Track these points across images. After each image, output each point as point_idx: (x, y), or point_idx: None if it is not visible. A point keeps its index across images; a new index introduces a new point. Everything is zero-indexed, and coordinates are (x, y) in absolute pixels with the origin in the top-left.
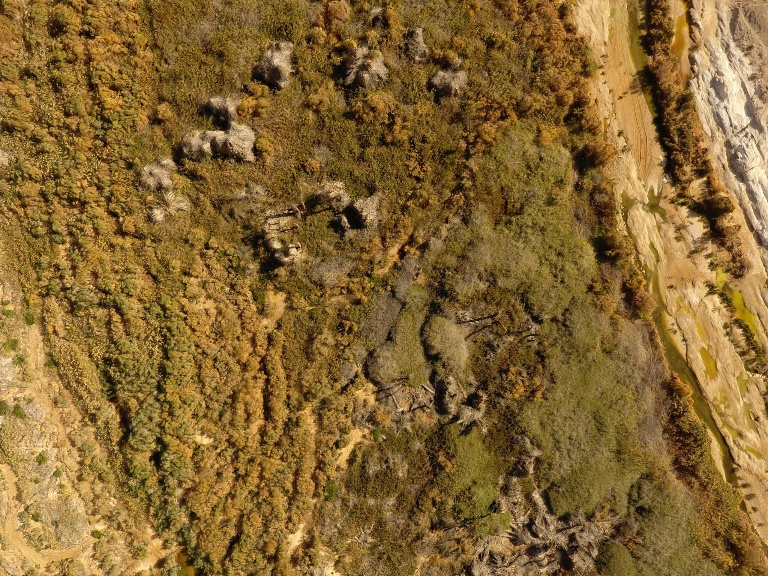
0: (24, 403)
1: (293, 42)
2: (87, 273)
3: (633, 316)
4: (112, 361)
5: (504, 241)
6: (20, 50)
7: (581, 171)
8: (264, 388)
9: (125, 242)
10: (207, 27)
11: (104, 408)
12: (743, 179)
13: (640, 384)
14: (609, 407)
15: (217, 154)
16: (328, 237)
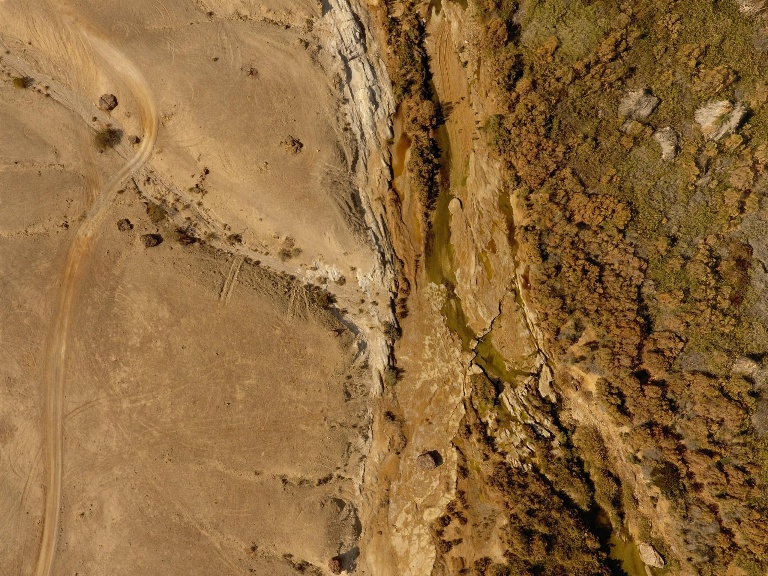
0: None
1: None
2: None
3: None
4: None
5: None
6: None
7: None
8: None
9: None
10: None
11: None
12: (354, 15)
13: None
14: None
15: None
16: None
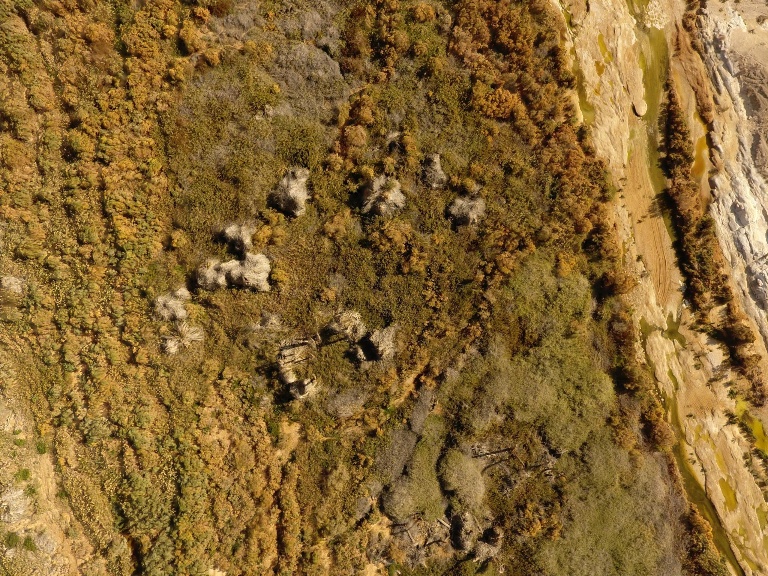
0: (35, 535)
1: (309, 168)
2: (100, 405)
3: (652, 449)
4: (124, 496)
5: (522, 373)
6: (33, 174)
7: (600, 299)
8: (278, 522)
9: (138, 373)
10: (222, 152)
11: (116, 544)
12: (764, 306)
13: (659, 520)
14: (627, 545)
15: (232, 285)
16: (343, 367)
